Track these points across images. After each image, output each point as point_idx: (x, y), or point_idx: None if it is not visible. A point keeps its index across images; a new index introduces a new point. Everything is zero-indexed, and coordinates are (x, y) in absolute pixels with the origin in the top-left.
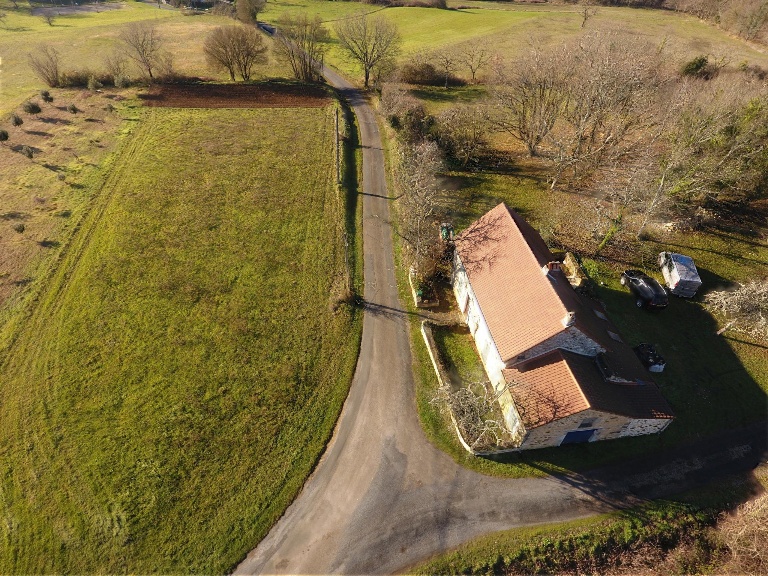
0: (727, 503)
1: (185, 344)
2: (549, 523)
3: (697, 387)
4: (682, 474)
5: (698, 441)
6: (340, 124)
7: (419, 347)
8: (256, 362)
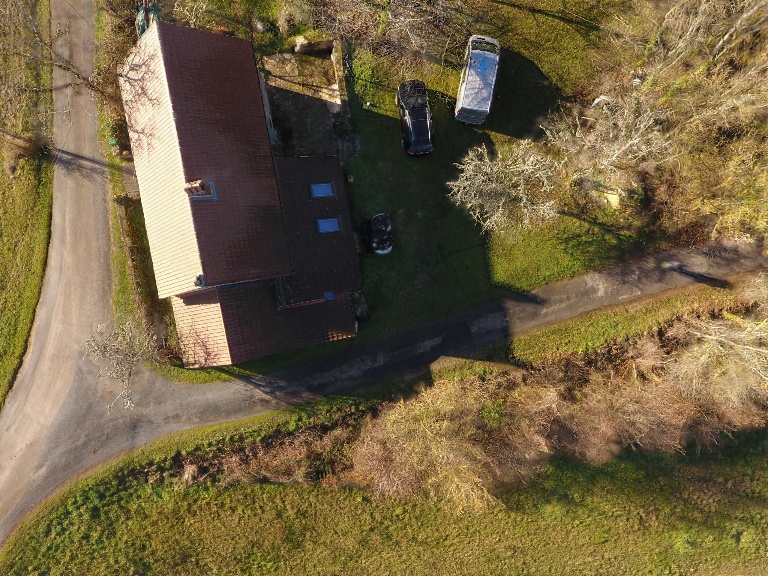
0: (392, 395)
1: None
2: (225, 422)
3: (418, 273)
4: (361, 371)
5: (391, 337)
6: None
7: None
8: None
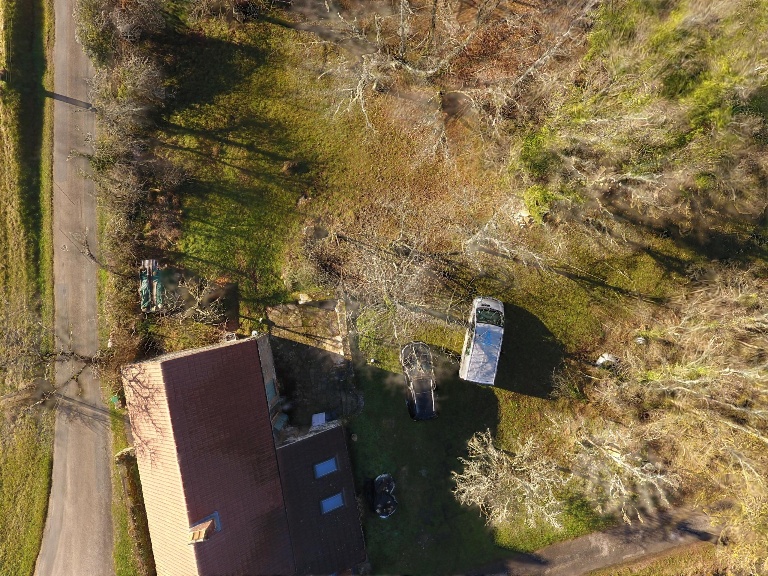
0: None
1: None
2: None
3: (421, 534)
4: None
5: None
6: None
7: None
8: None
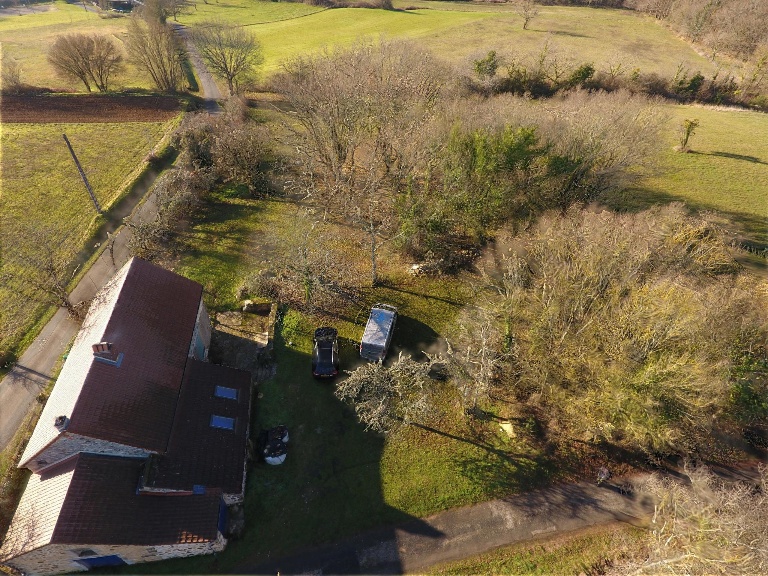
0: None
1: None
2: None
3: (307, 486)
4: None
5: (263, 563)
6: (164, 141)
7: None
8: None
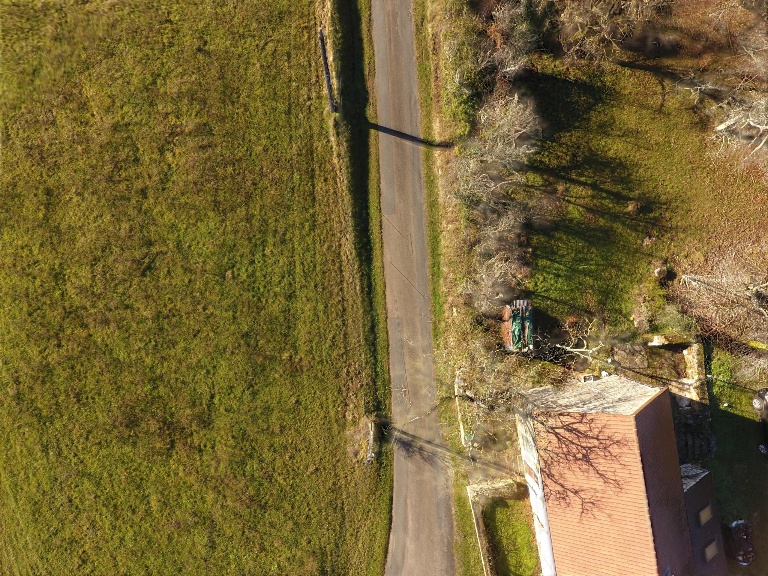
0: None
1: (180, 527)
2: None
3: None
4: None
5: None
6: None
7: (463, 514)
8: (271, 549)
